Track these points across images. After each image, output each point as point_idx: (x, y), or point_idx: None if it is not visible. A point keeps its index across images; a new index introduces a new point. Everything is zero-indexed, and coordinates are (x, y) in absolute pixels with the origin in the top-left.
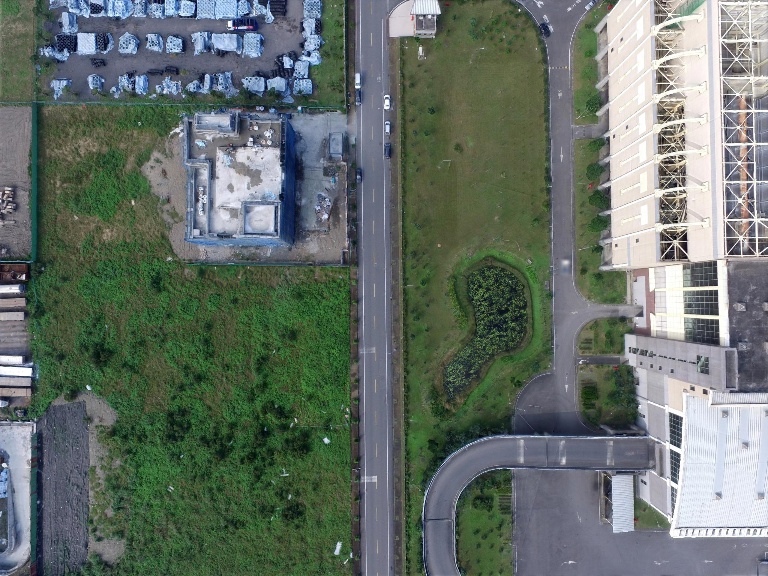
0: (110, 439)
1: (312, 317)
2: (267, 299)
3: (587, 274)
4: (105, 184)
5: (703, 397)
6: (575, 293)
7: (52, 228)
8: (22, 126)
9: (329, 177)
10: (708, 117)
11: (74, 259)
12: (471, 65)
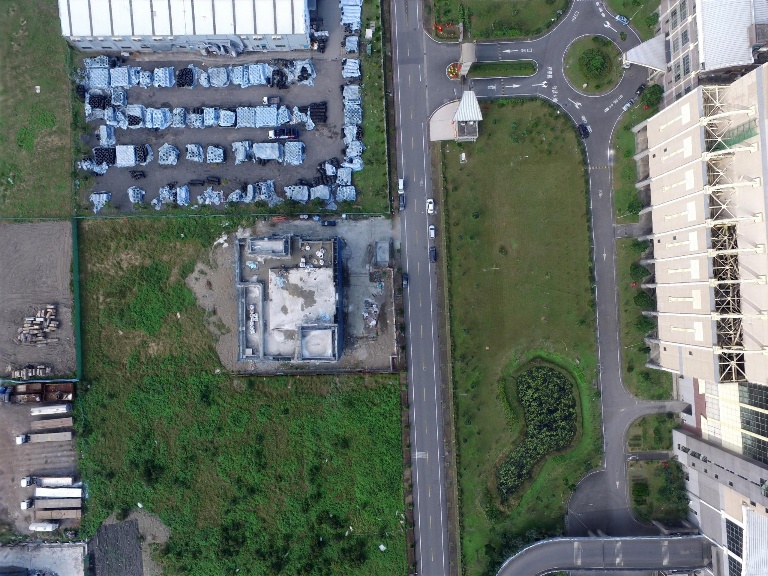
0: (164, 557)
1: (364, 424)
2: (318, 408)
3: (634, 371)
4: (149, 298)
5: (766, 516)
6: (622, 390)
7: (97, 344)
8: (62, 241)
9: (375, 283)
10: (765, 248)
11: (120, 375)
12: (512, 167)
